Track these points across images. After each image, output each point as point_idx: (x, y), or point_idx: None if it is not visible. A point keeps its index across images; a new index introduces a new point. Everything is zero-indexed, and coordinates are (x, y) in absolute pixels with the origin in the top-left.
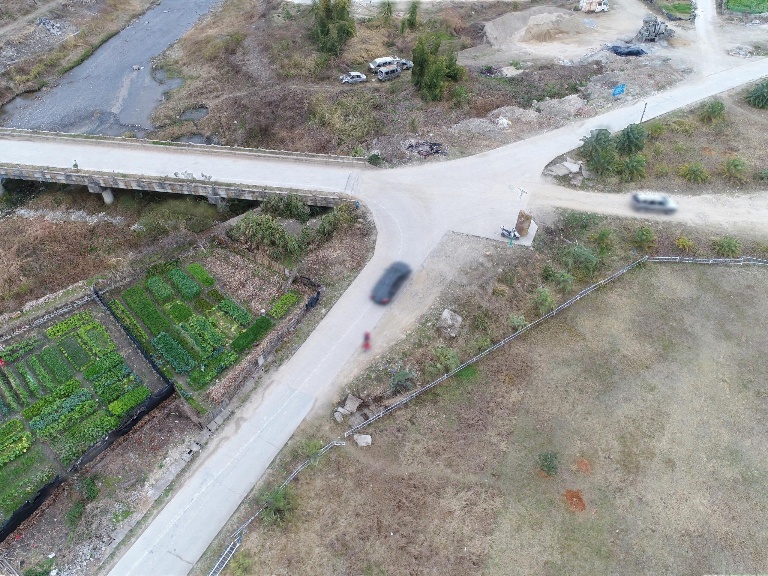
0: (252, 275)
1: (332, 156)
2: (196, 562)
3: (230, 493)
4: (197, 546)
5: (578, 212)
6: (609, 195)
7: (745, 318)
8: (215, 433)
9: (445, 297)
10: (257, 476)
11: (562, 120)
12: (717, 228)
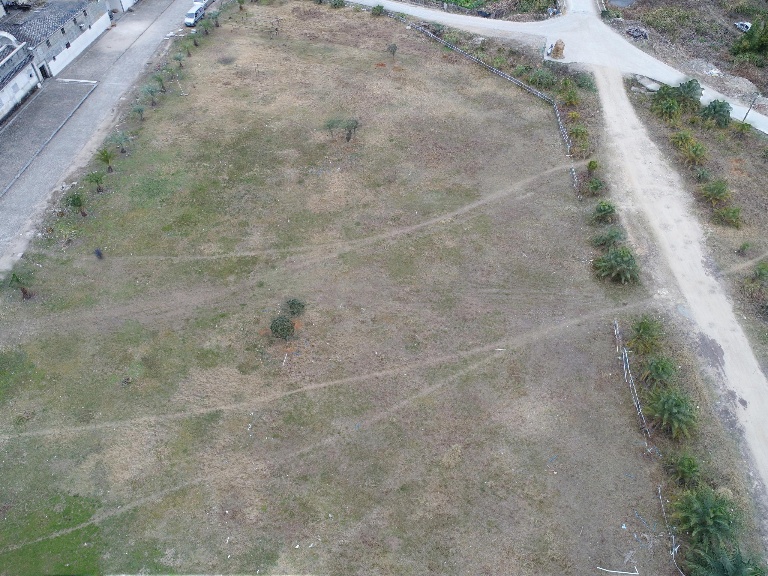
0: (504, 8)
1: (603, 4)
2: (360, 4)
3: (384, 6)
4: (365, 3)
5: (593, 82)
6: (627, 101)
7: (508, 130)
8: (410, 3)
9: (493, 38)
10: (391, 10)
11: (739, 98)
12: (606, 139)
